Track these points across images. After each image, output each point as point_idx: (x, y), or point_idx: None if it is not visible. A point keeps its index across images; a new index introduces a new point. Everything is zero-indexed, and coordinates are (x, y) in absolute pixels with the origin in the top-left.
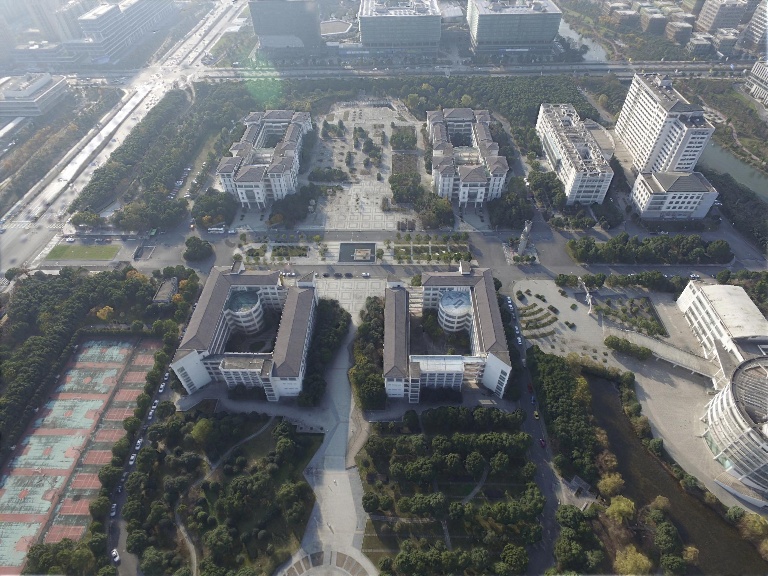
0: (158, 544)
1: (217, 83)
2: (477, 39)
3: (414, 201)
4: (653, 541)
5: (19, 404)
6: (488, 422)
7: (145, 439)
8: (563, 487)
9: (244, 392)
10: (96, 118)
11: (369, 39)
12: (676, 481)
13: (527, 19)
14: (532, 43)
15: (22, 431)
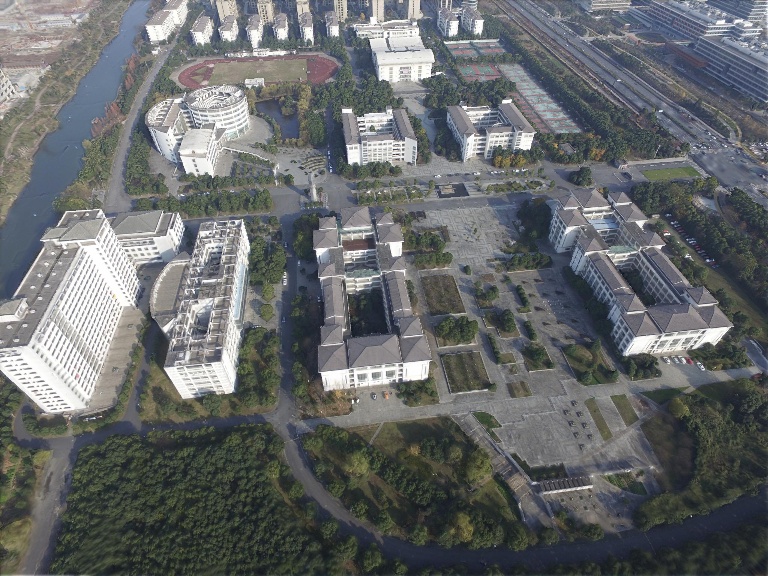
0: None
1: None
2: None
3: None
4: (293, 103)
5: None
6: None
7: None
8: None
9: None
10: None
11: None
12: None
13: None
14: None
15: None
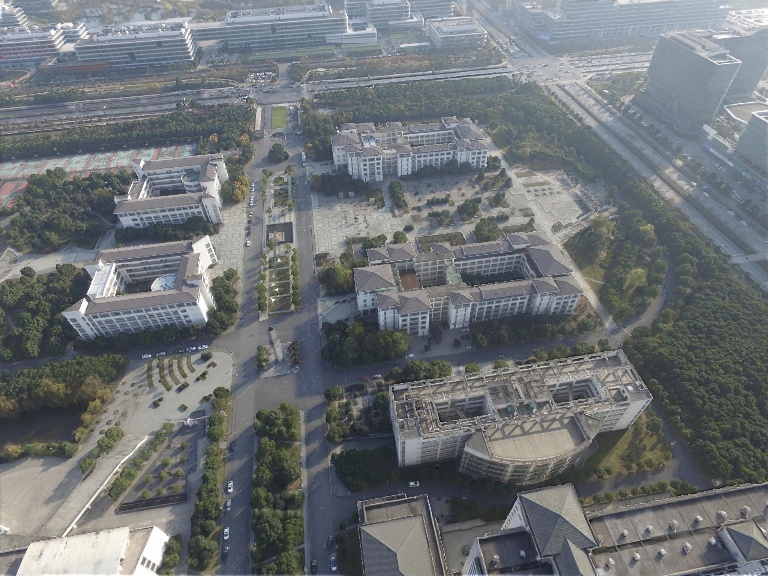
0: (52, 205)
1: (538, 92)
2: None
3: None
4: None
5: (147, 137)
6: None
7: None
8: None
9: None
10: (449, 67)
11: (745, 150)
12: None
13: None
14: None
15: (137, 146)
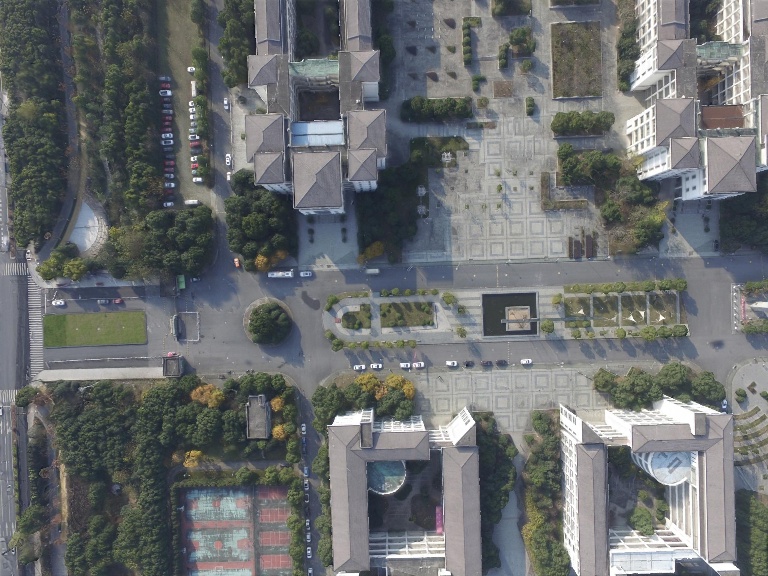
0: None
1: None
2: None
3: (596, 181)
4: None
5: None
6: None
7: None
8: None
9: None
10: None
11: None
12: None
13: None
14: None
15: None
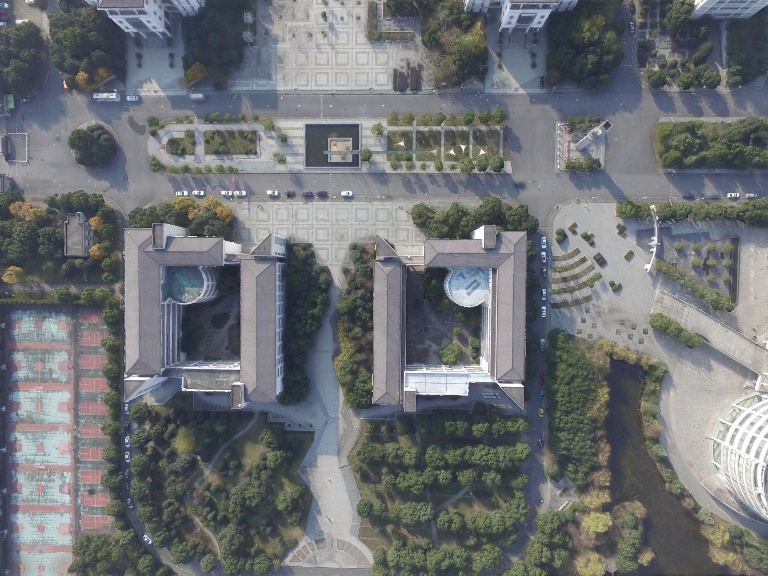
0: (181, 532)
1: None
2: None
3: (422, 12)
4: (617, 543)
5: None
6: None
7: None
8: (550, 487)
9: None
10: None
11: None
12: (663, 481)
13: None
14: None
15: (2, 428)
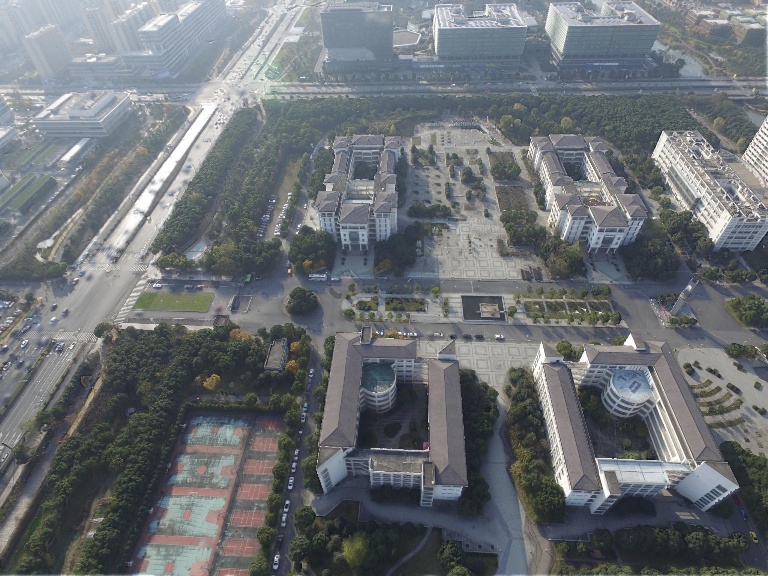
0: None
1: (289, 101)
2: (563, 52)
3: (534, 244)
4: None
5: (132, 505)
6: (705, 551)
7: (282, 554)
8: None
9: (392, 494)
10: (164, 139)
11: (446, 52)
12: None
13: (621, 31)
14: (623, 57)
15: (137, 539)
